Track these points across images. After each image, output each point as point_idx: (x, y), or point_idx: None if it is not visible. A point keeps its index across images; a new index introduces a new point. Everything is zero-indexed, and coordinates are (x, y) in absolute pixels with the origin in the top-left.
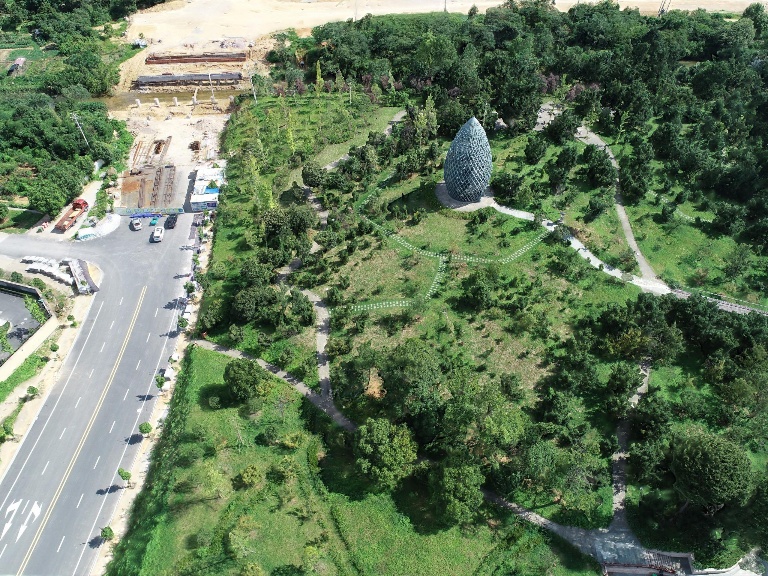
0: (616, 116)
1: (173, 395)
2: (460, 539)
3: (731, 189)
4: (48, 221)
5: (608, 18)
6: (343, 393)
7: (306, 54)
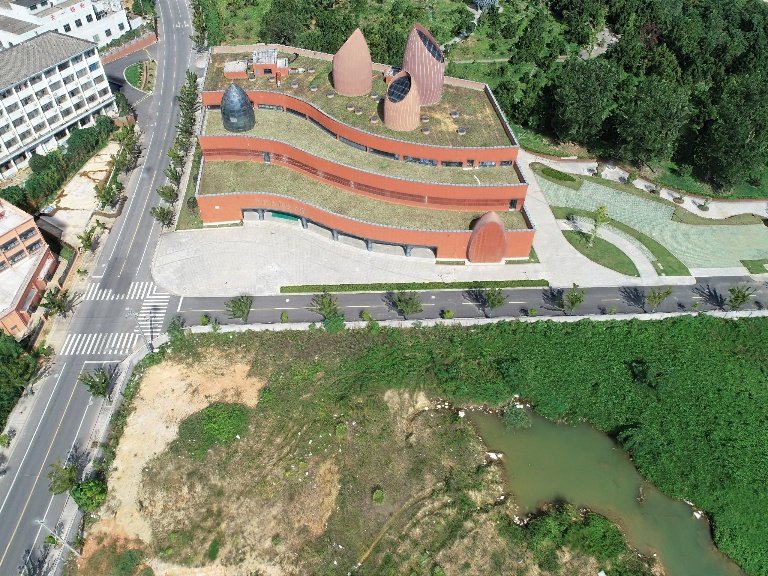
0: None
1: None
2: None
3: None
4: None
5: None
6: None
7: None
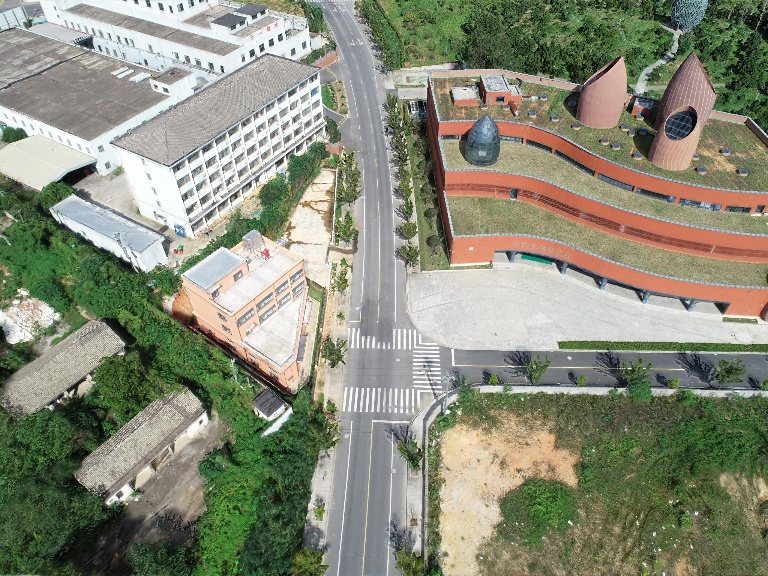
0: None
1: None
2: (461, 34)
3: None
4: None
5: None
6: None
7: None
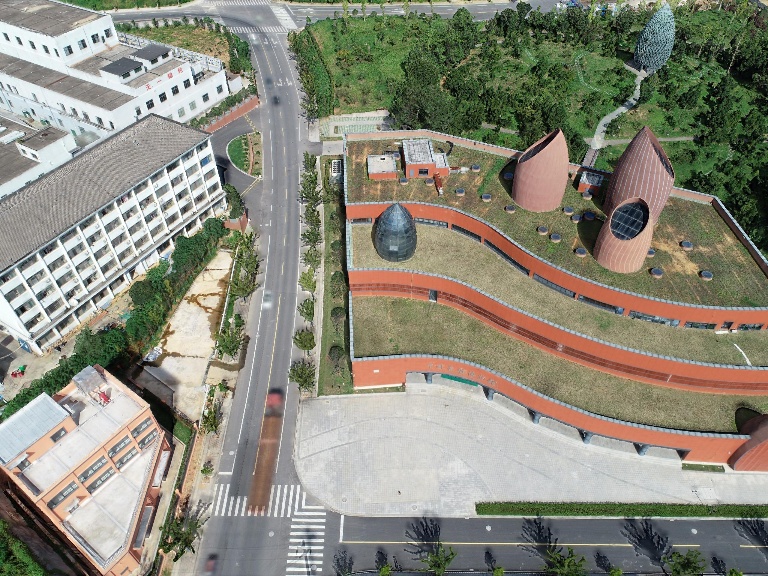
0: None
1: None
2: (401, 74)
3: None
4: None
5: None
6: None
7: None
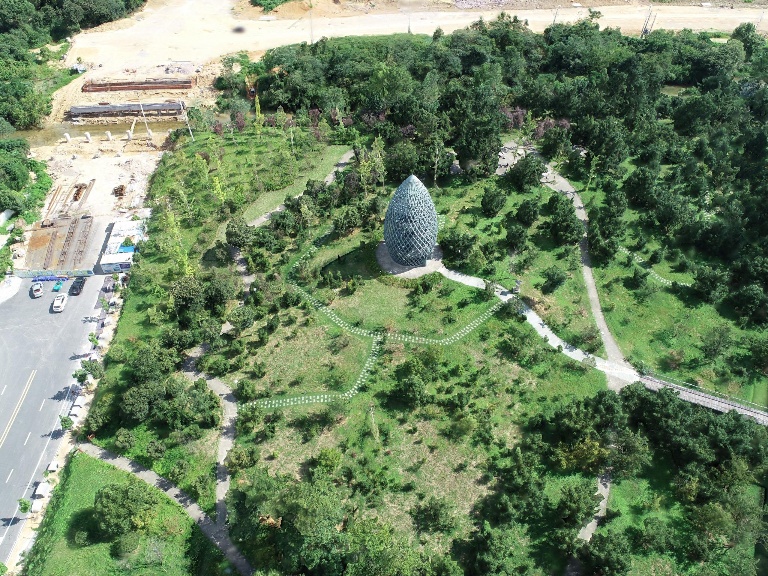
0: (588, 157)
1: (43, 518)
2: None
3: (713, 246)
4: None
5: (586, 40)
6: (232, 532)
7: (257, 80)
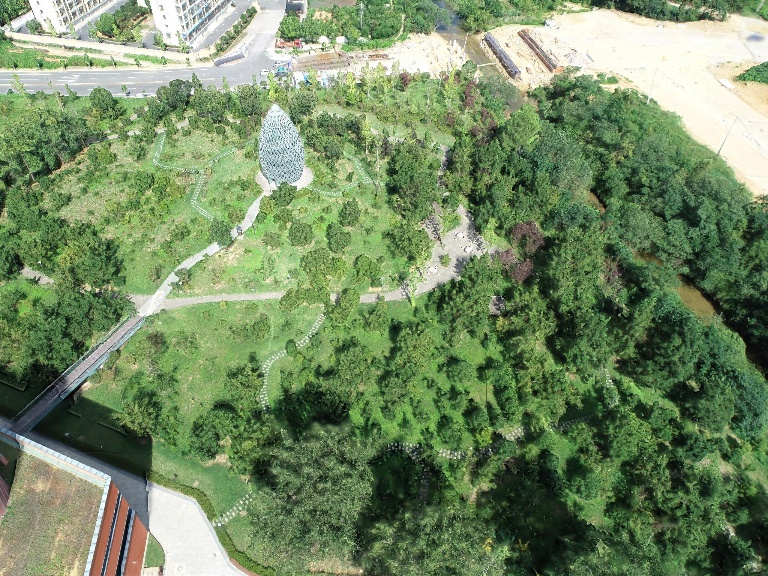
0: None
1: None
2: None
3: None
4: (287, 41)
5: None
6: None
7: None
